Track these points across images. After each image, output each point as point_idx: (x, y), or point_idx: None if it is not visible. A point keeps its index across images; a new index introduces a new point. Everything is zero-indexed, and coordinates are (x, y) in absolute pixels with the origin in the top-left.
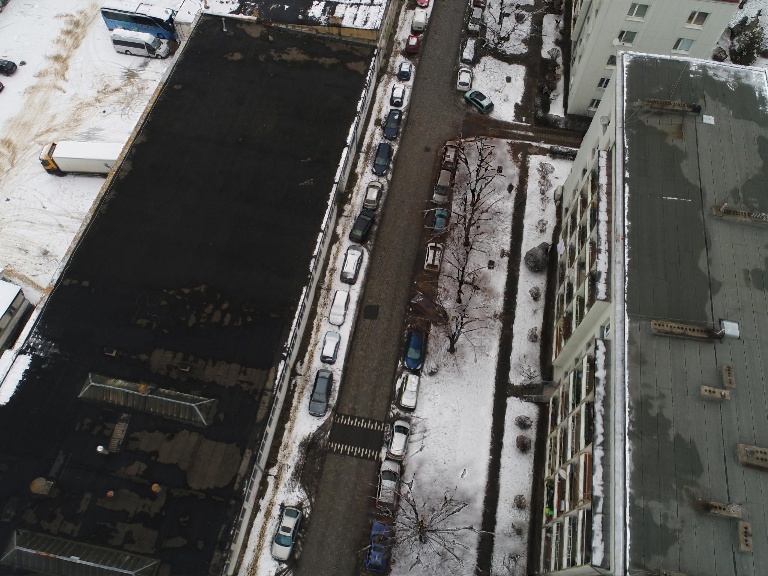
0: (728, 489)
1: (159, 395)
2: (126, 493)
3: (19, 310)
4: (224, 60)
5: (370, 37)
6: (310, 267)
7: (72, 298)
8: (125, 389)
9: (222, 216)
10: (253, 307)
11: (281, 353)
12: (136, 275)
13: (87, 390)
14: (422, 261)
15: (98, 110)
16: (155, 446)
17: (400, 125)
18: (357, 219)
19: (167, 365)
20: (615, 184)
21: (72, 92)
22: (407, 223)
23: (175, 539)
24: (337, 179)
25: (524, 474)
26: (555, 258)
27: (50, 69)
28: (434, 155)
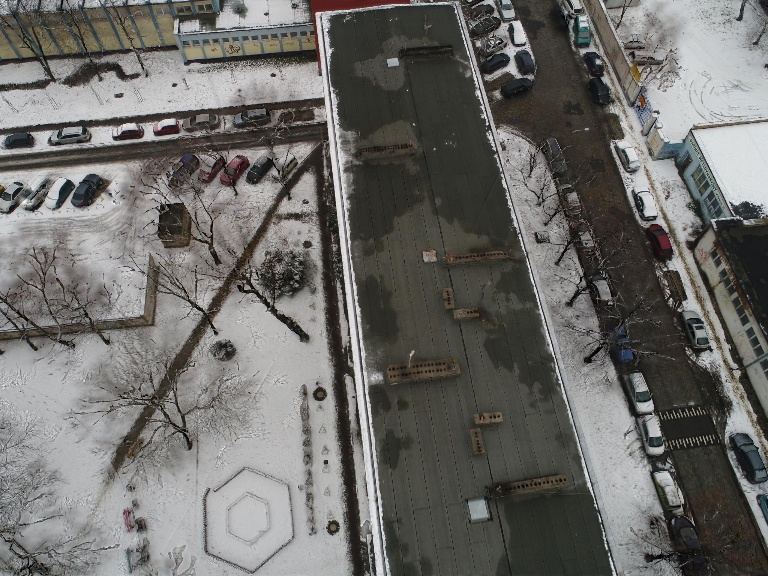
0: (462, 335)
1: None
2: None
3: None
4: None
5: None
6: None
7: None
8: None
9: None
10: None
11: None
12: None
13: None
14: None
15: None
16: None
17: None
18: None
19: None
20: None
21: None
22: None
23: None
24: None
25: None
26: None
27: None
28: None
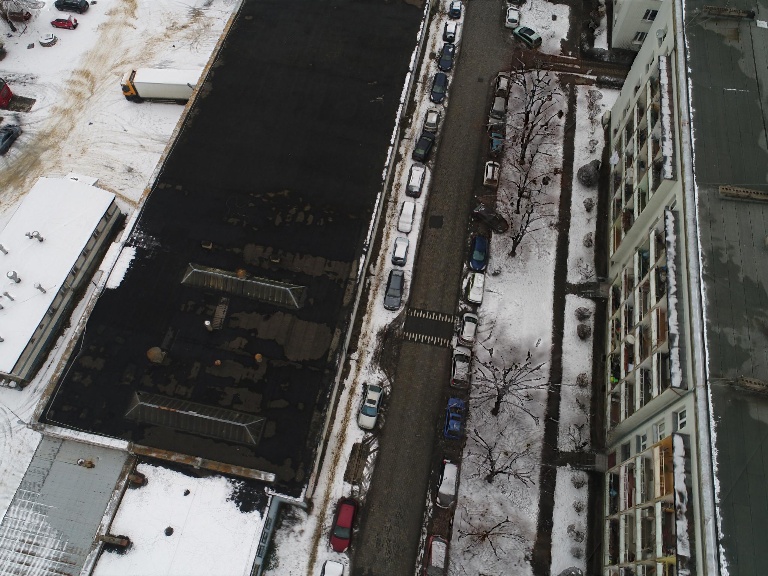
0: None
1: (255, 280)
2: (231, 363)
3: (112, 217)
4: None
5: None
6: (383, 176)
7: (168, 200)
8: (225, 275)
9: (299, 131)
10: (333, 209)
11: (361, 248)
12: (224, 181)
13: (190, 276)
14: (481, 178)
15: (168, 45)
16: (254, 325)
17: (453, 58)
18: (419, 140)
19: (259, 257)
20: (676, 82)
21: (142, 28)
22: (465, 145)
23: (278, 401)
24: (402, 100)
25: (584, 359)
26: (605, 175)
27: (120, 8)
28: (487, 85)
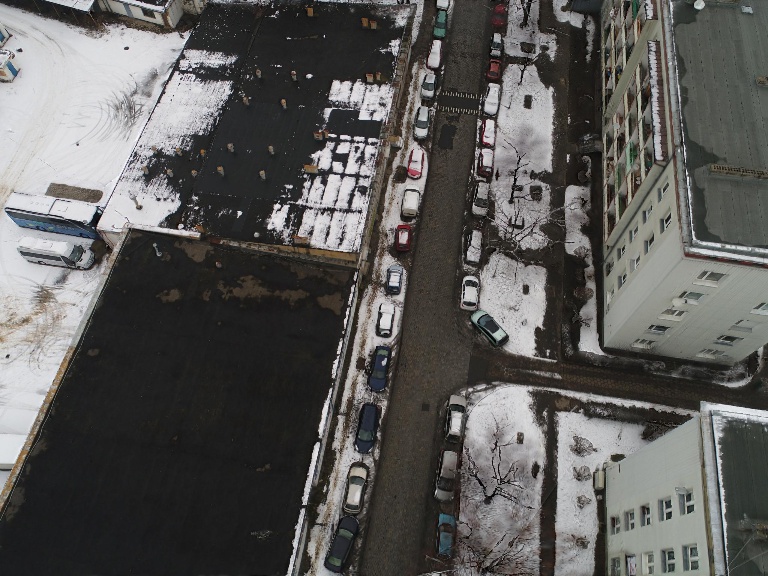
0: None
1: None
2: None
3: None
4: (157, 303)
5: (348, 258)
6: None
7: None
8: None
9: None
10: None
11: None
12: None
13: None
14: None
15: None
16: None
17: (389, 367)
18: (334, 537)
19: None
20: None
21: None
22: (401, 534)
23: None
24: (305, 500)
25: None
26: None
27: None
28: (434, 416)
